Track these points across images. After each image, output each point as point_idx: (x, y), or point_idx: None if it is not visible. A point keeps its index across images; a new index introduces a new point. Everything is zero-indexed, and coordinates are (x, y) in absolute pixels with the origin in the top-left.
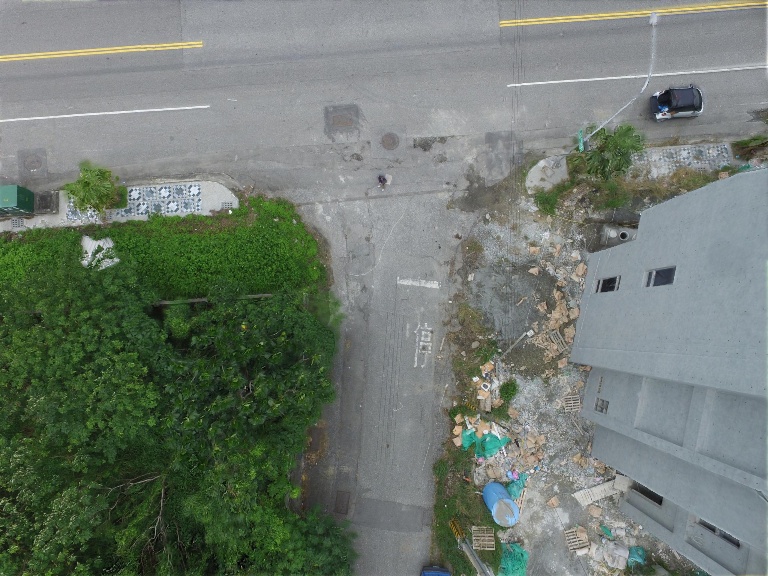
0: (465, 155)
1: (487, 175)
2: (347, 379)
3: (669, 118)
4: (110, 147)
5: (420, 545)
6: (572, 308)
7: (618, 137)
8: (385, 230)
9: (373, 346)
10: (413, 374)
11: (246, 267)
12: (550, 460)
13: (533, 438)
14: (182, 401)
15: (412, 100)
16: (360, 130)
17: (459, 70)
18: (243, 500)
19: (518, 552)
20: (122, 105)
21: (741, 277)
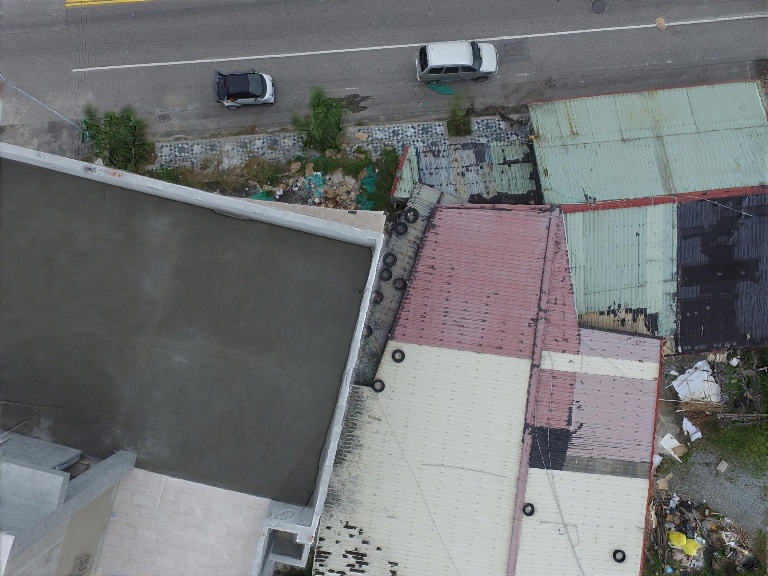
0: None
1: None
2: None
3: (239, 105)
4: None
5: None
6: None
7: (110, 127)
8: None
9: None
10: None
11: None
12: None
13: None
14: None
15: None
16: None
17: (19, 53)
18: None
19: None
20: None
21: None
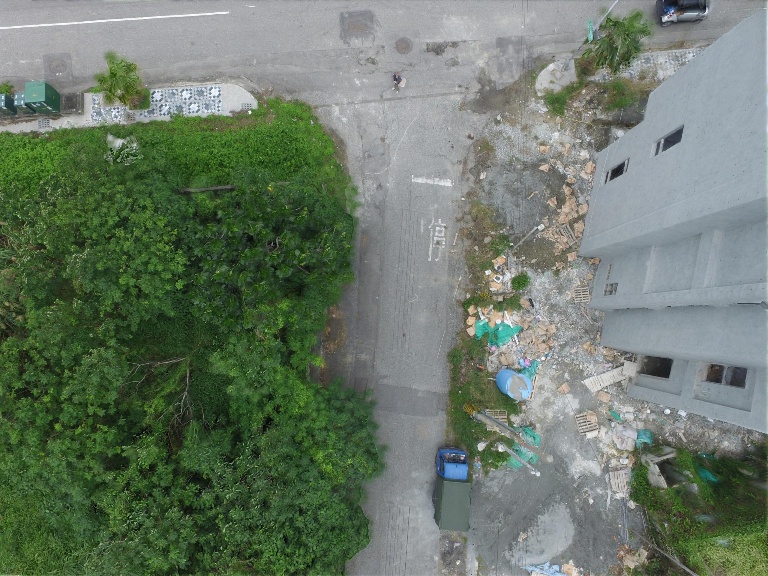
0: (477, 59)
1: (498, 78)
2: (364, 272)
3: (674, 22)
4: (133, 52)
5: (435, 428)
6: (581, 204)
7: None
8: (399, 131)
9: (389, 241)
10: (428, 267)
11: (266, 162)
12: (560, 349)
13: (544, 326)
14: (211, 261)
15: (425, 6)
16: (375, 35)
17: None
18: (271, 346)
19: (530, 435)
20: (144, 11)
21: (747, 105)
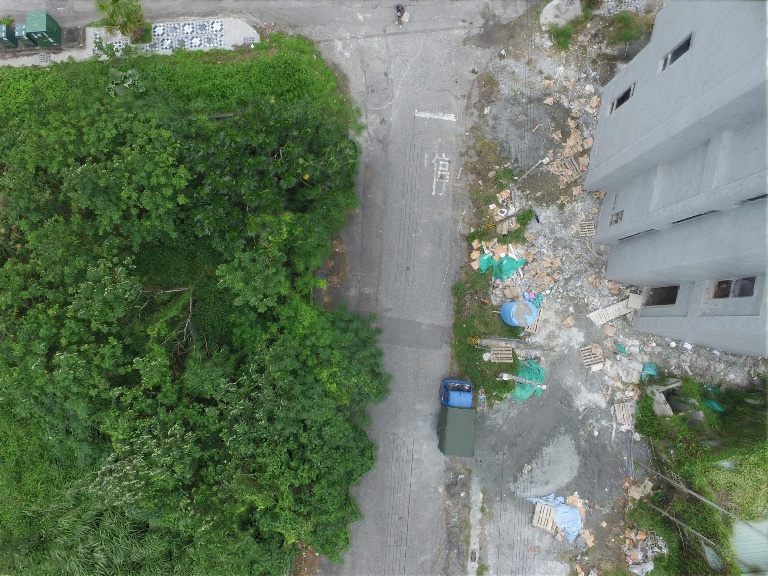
0: None
1: (502, 13)
2: (367, 206)
3: None
4: None
5: (440, 361)
6: (586, 138)
7: None
8: (403, 65)
9: (392, 175)
10: (431, 201)
11: (269, 93)
12: (565, 282)
13: (549, 258)
14: (214, 175)
15: None
16: None
17: None
18: (275, 256)
19: (535, 368)
20: None
21: None
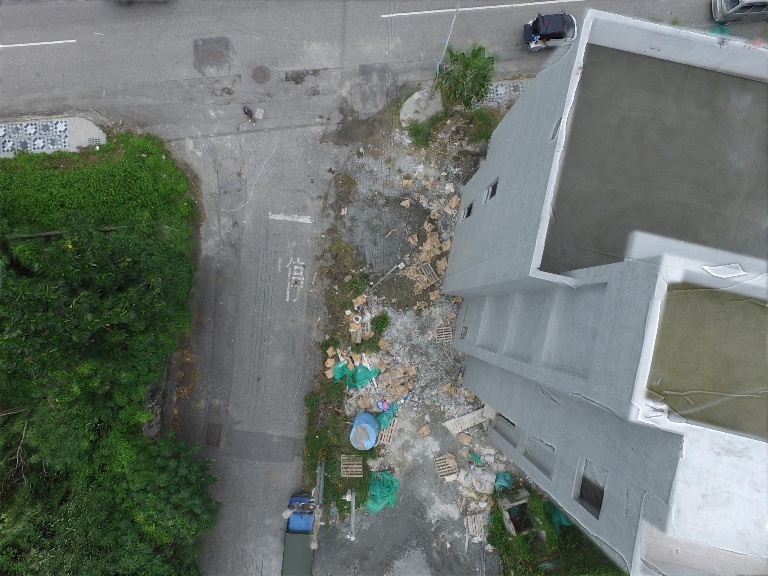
0: (338, 88)
1: (361, 108)
2: (219, 314)
3: (544, 47)
4: None
5: (291, 474)
6: (445, 241)
7: None
8: (257, 165)
9: (245, 281)
10: (285, 308)
11: (110, 202)
12: (421, 390)
13: (402, 368)
14: (12, 322)
15: (283, 32)
16: (231, 63)
17: (332, 1)
18: (67, 415)
19: (388, 479)
20: None
21: (525, 171)
